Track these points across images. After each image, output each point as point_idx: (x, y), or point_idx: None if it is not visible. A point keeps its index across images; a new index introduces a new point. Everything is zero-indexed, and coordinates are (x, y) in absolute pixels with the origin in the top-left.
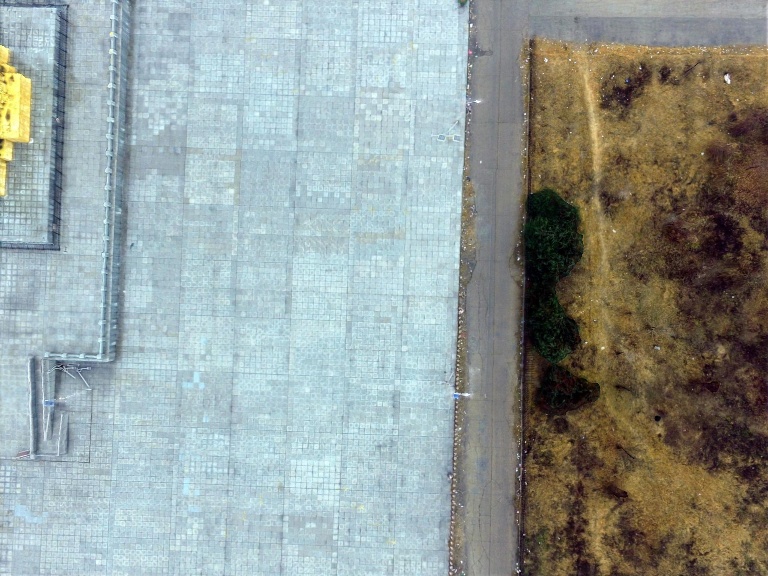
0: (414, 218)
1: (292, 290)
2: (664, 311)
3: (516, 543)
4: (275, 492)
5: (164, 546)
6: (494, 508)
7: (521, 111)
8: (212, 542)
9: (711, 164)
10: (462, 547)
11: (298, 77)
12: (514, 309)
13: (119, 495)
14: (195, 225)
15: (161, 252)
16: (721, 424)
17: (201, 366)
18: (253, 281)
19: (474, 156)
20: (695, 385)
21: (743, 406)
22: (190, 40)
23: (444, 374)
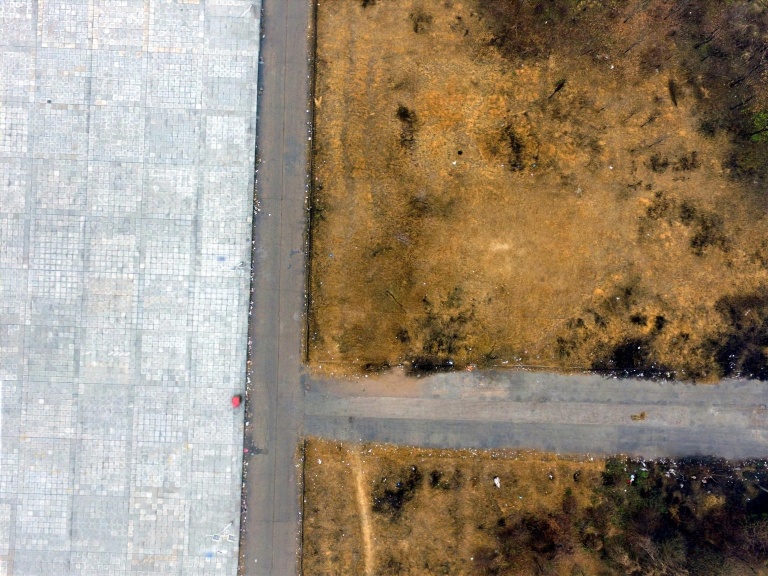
0: None
1: None
2: None
3: None
4: None
5: None
6: None
7: (296, 510)
8: None
9: (480, 570)
10: None
11: (72, 476)
12: None
13: None
14: None
15: None
16: None
17: None
18: None
19: (249, 554)
20: None
21: None
22: None
23: None
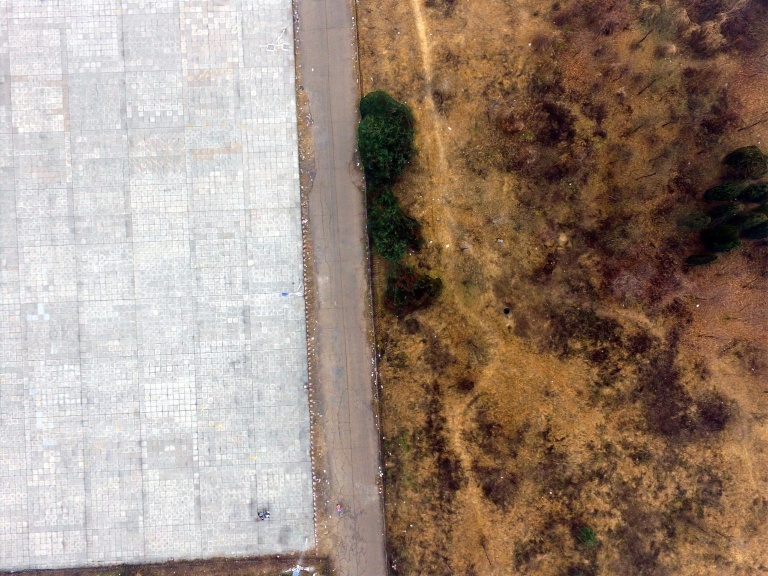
0: (249, 131)
1: (131, 213)
2: (504, 204)
3: (377, 447)
4: (131, 418)
5: (21, 483)
6: (353, 414)
7: (349, 15)
8: (70, 474)
9: (539, 54)
10: (324, 456)
11: None
12: (357, 215)
13: None
14: (26, 155)
15: None
16: (568, 311)
17: (44, 297)
18: (91, 207)
19: (305, 64)
20: (539, 274)
21: (588, 291)
22: None
23: (292, 285)
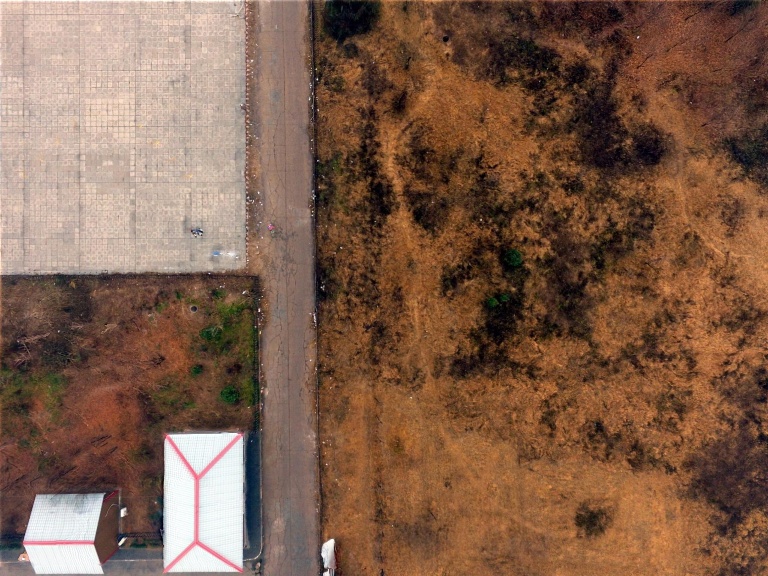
0: None
1: None
2: None
3: (311, 171)
4: (71, 132)
5: None
6: (288, 137)
7: None
8: (10, 184)
9: None
10: (258, 178)
11: None
12: None
13: None
14: None
15: None
16: (507, 39)
17: None
18: None
19: None
20: None
21: (528, 20)
22: None
23: (234, 7)
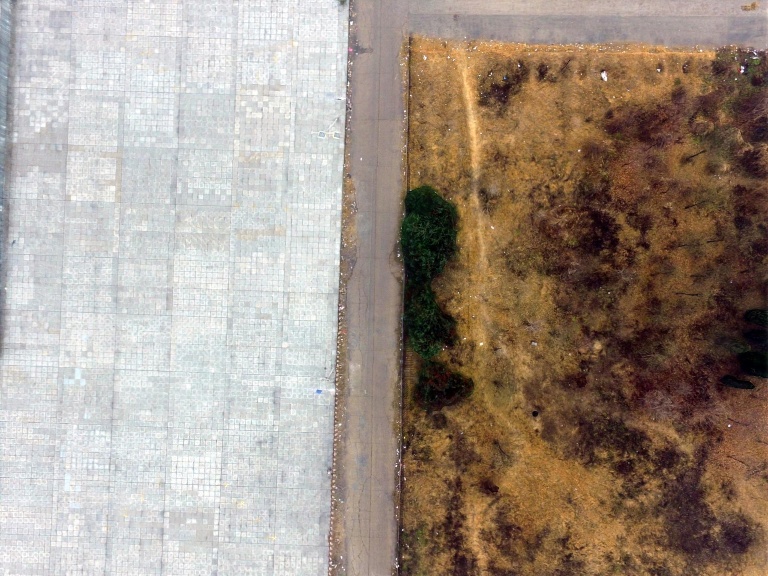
0: (294, 215)
1: (173, 287)
2: (541, 307)
3: (395, 538)
4: (156, 488)
5: (45, 542)
6: (374, 503)
7: (401, 108)
8: (93, 538)
9: (587, 161)
10: (342, 542)
11: (179, 74)
12: (394, 305)
13: (0, 492)
14: (76, 222)
15: (43, 249)
16: (597, 419)
17: (82, 363)
18: (134, 278)
19: (355, 153)
20: (571, 380)
21: (619, 401)
22: (71, 38)
23: (324, 370)
